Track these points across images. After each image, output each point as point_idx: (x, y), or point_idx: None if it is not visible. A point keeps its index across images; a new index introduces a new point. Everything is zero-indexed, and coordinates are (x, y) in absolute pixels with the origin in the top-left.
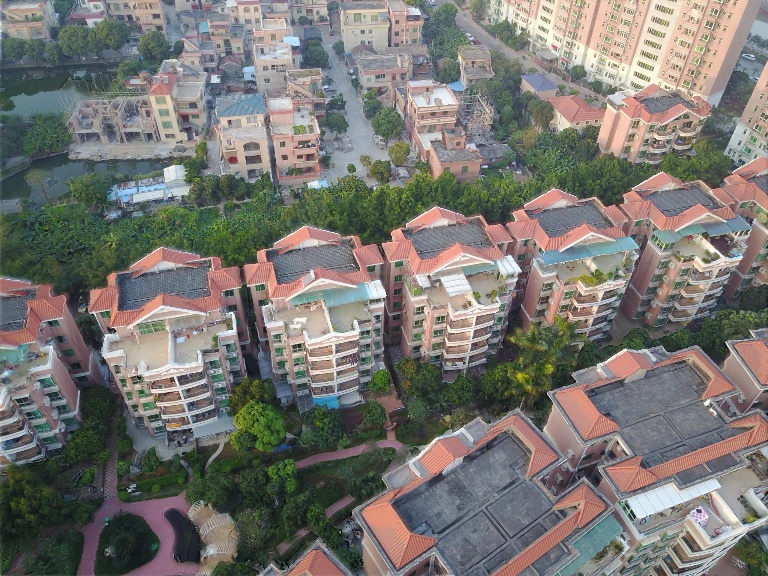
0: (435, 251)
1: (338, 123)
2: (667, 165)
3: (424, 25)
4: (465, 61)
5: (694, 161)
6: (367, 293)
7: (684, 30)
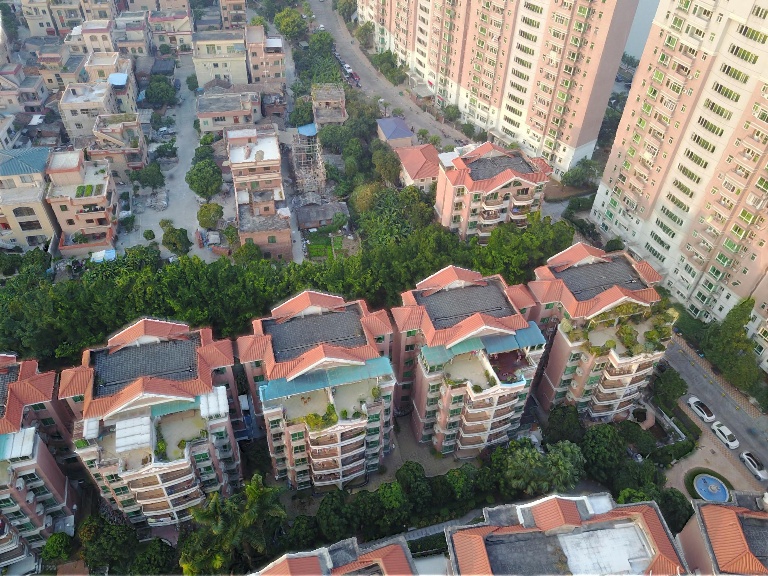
0: (124, 382)
1: (148, 178)
2: (495, 240)
3: (296, 56)
4: (316, 102)
5: (524, 237)
6: (4, 450)
7: (545, 73)
